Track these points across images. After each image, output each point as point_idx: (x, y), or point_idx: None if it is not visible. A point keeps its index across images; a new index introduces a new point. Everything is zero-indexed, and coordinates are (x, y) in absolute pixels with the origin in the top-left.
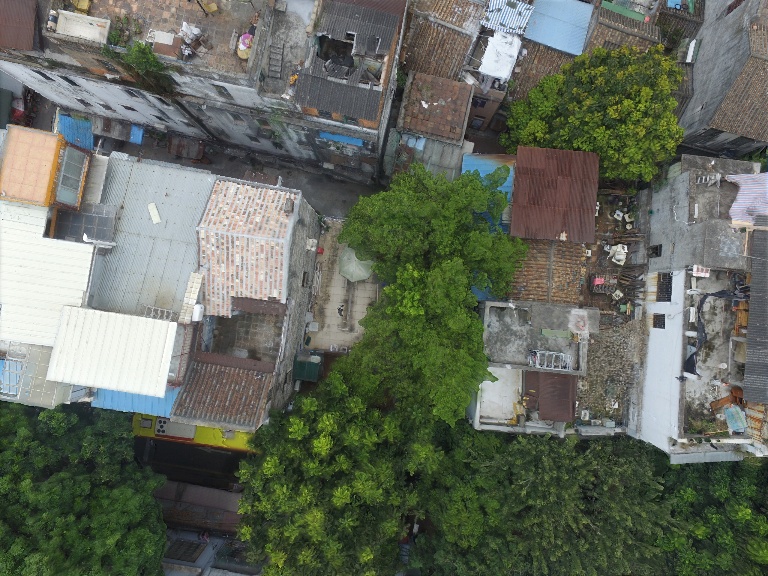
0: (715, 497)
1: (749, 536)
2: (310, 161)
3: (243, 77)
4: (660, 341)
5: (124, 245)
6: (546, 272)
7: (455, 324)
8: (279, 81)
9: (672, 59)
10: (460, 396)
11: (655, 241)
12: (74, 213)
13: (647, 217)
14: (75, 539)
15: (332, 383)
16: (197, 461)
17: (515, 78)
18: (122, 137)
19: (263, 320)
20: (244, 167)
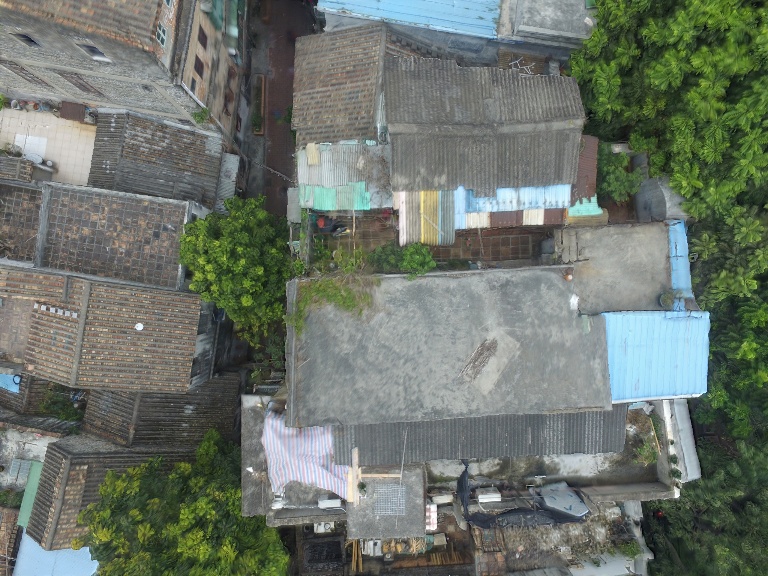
0: None
1: None
2: None
3: None
4: None
5: None
6: None
7: None
8: None
9: (93, 522)
10: None
11: None
12: None
13: None
14: None
15: None
16: None
17: None
18: None
19: None
20: None
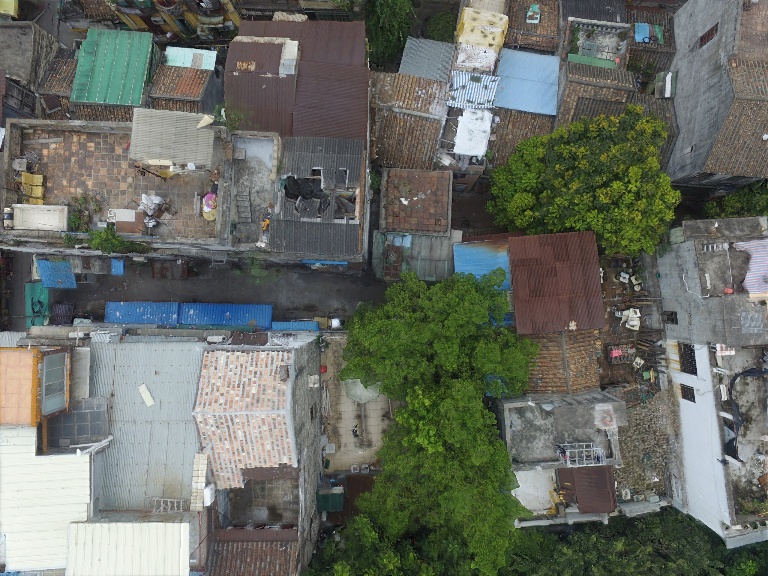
0: None
1: None
2: (297, 265)
3: (213, 242)
4: (693, 415)
5: (121, 435)
6: (561, 362)
7: (478, 459)
8: (251, 225)
9: (654, 119)
10: (497, 544)
11: (668, 307)
12: (64, 413)
13: (655, 280)
14: None
15: (360, 528)
16: None
17: (492, 146)
18: (103, 271)
19: None
20: (231, 273)
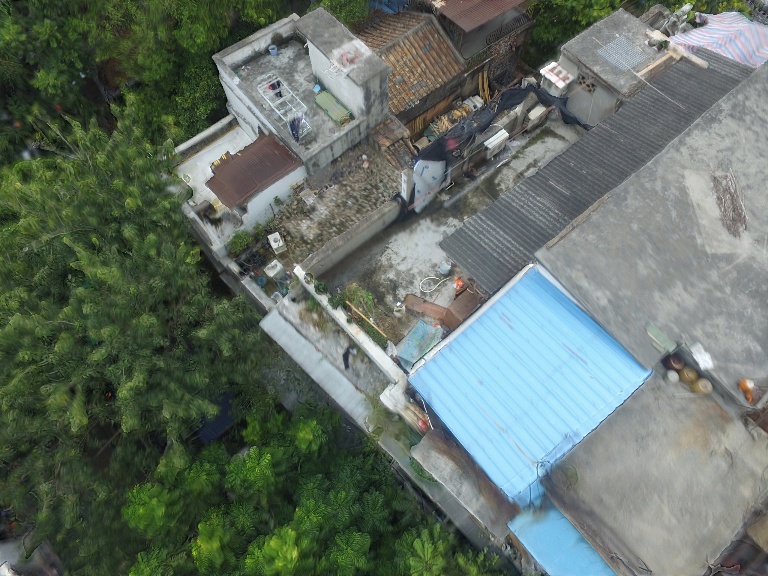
0: None
1: None
2: None
3: None
4: None
5: None
6: (388, 42)
7: None
8: None
9: None
10: None
11: None
12: None
13: None
14: None
15: None
16: None
17: None
18: None
19: None
20: None
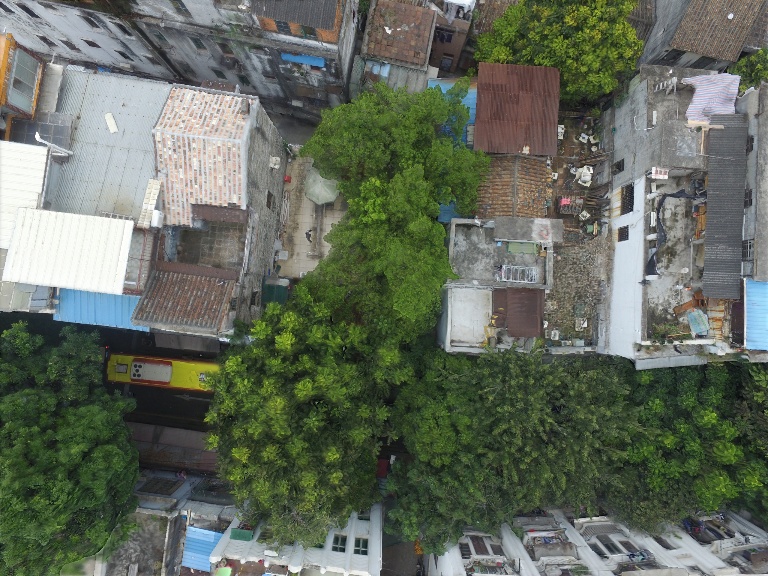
0: (683, 408)
1: (715, 440)
2: (278, 99)
3: None
4: (624, 253)
5: (81, 154)
6: (511, 188)
7: (415, 225)
8: None
9: None
10: (420, 291)
11: (618, 157)
12: (29, 122)
13: (611, 135)
14: (40, 449)
15: (297, 296)
16: (176, 409)
17: (480, 10)
18: None
19: (227, 236)
20: None
